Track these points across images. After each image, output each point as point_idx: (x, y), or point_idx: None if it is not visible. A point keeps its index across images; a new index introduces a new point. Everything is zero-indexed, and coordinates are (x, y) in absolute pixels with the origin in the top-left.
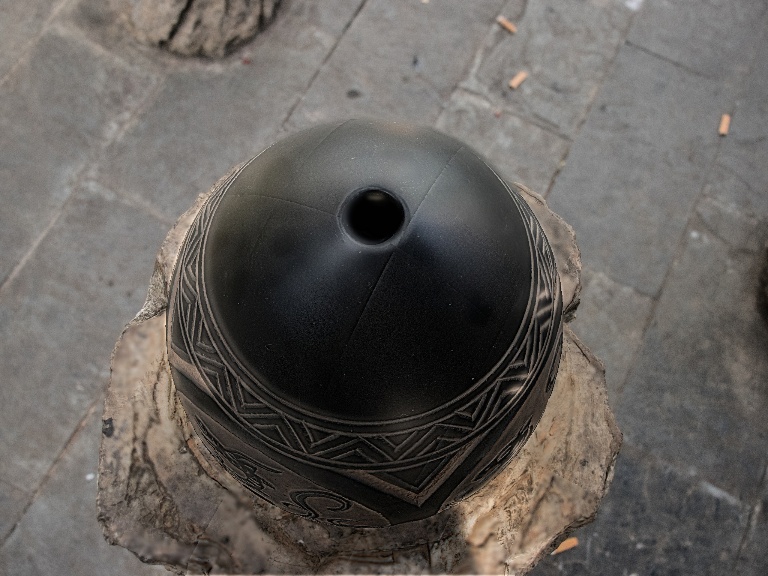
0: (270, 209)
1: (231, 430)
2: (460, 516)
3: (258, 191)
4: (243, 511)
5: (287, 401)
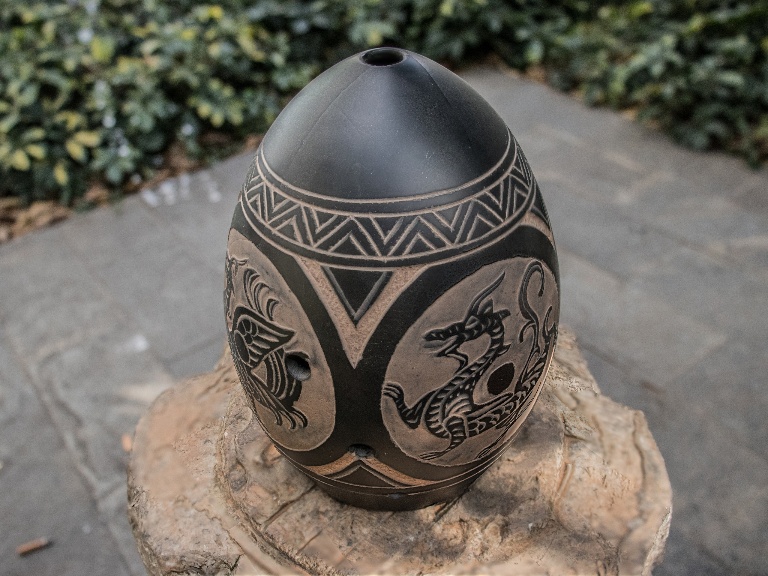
0: (335, 110)
1: (459, 276)
2: (549, 403)
3: (311, 125)
4: (481, 571)
5: (467, 183)
